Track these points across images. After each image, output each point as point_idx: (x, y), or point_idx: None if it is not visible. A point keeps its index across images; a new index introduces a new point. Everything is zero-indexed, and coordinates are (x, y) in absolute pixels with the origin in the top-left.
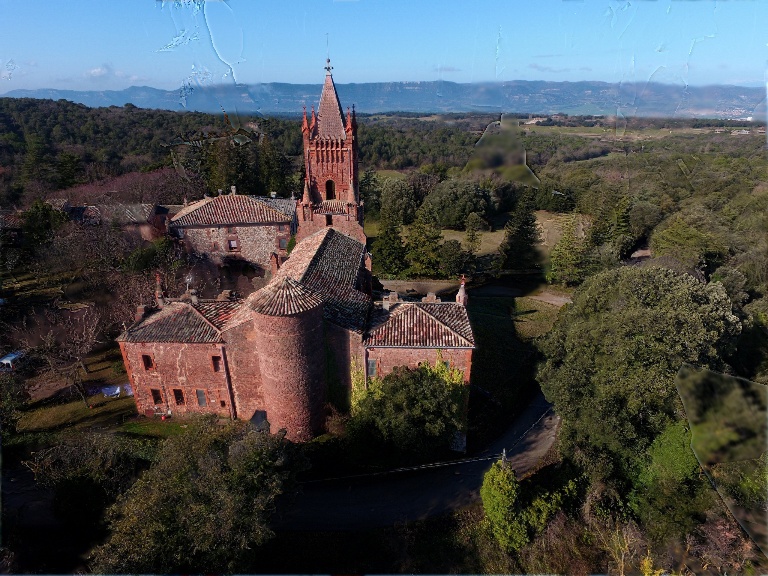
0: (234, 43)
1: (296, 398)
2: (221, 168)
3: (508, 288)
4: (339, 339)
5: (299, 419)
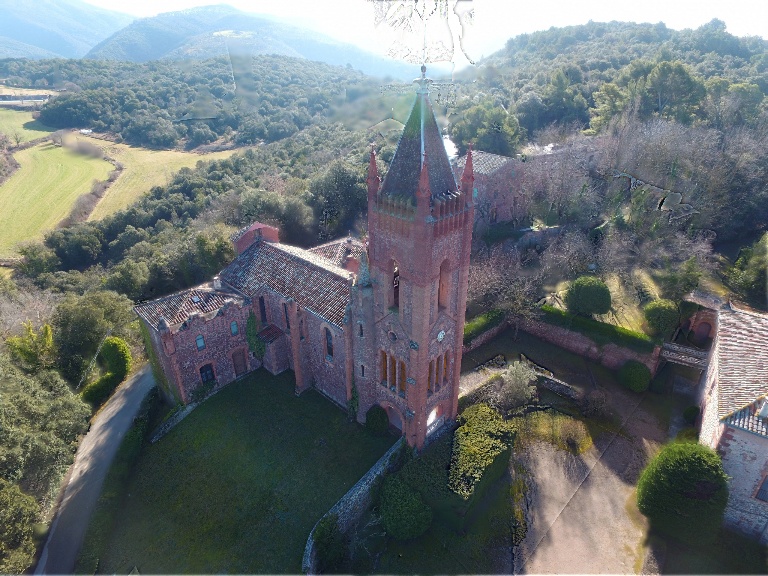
0: None
1: None
2: None
3: None
4: None
5: None
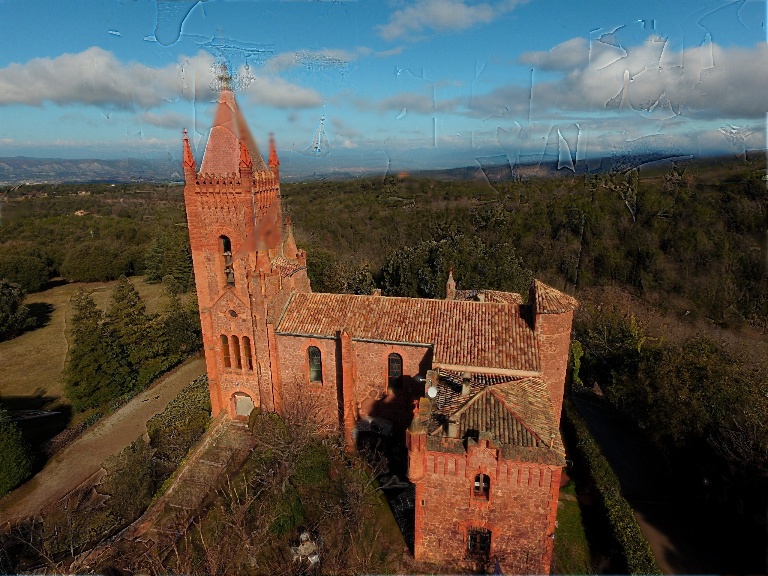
0: None
1: None
2: None
3: None
4: None
5: None
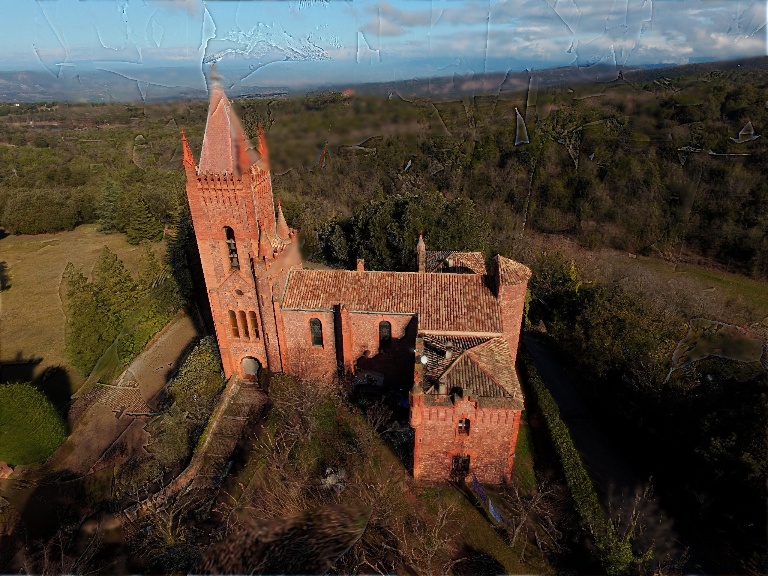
0: None
1: None
2: None
3: None
4: None
5: None
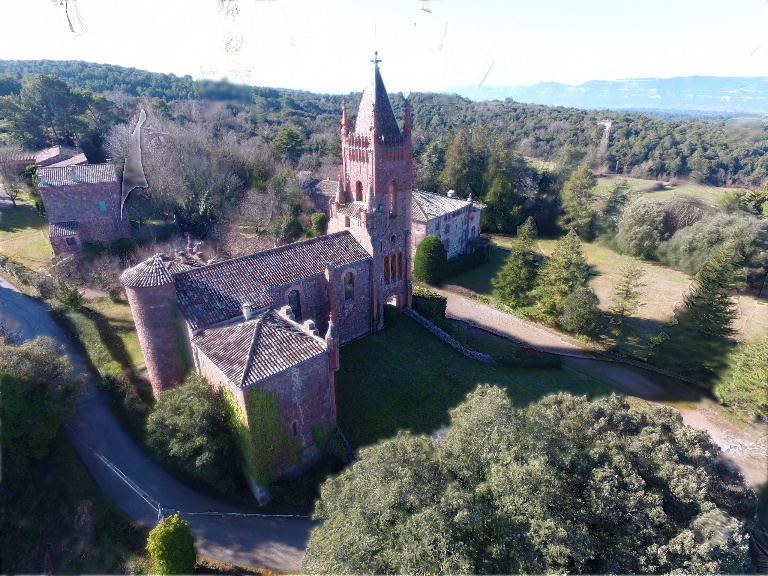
0: None
1: (149, 362)
2: (450, 162)
3: (645, 381)
4: (184, 326)
5: (154, 382)
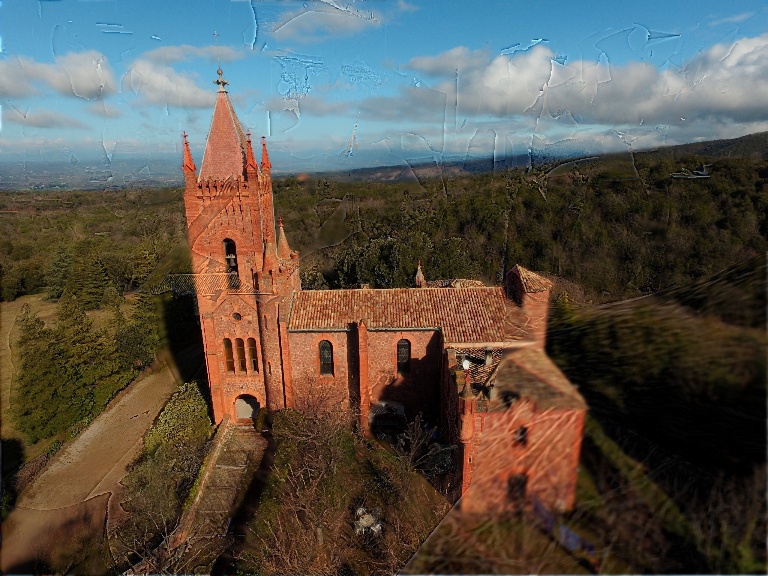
0: (239, 17)
1: None
2: None
3: (187, 349)
4: None
5: None
